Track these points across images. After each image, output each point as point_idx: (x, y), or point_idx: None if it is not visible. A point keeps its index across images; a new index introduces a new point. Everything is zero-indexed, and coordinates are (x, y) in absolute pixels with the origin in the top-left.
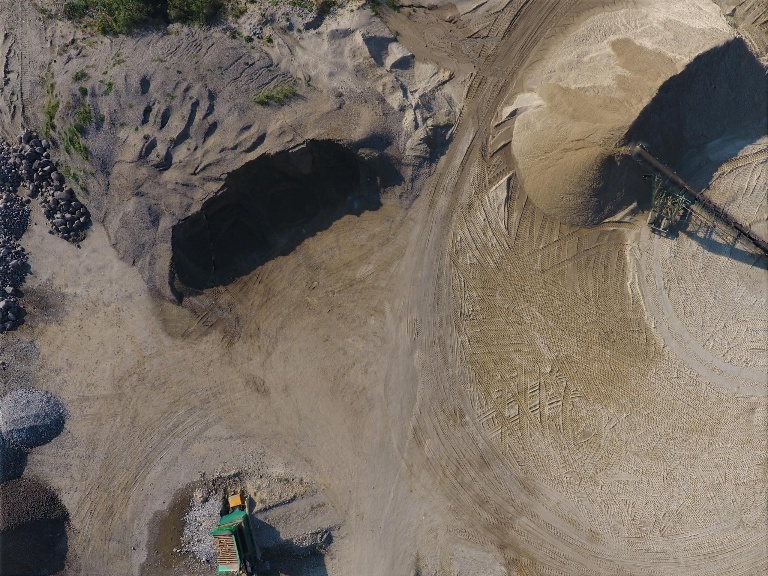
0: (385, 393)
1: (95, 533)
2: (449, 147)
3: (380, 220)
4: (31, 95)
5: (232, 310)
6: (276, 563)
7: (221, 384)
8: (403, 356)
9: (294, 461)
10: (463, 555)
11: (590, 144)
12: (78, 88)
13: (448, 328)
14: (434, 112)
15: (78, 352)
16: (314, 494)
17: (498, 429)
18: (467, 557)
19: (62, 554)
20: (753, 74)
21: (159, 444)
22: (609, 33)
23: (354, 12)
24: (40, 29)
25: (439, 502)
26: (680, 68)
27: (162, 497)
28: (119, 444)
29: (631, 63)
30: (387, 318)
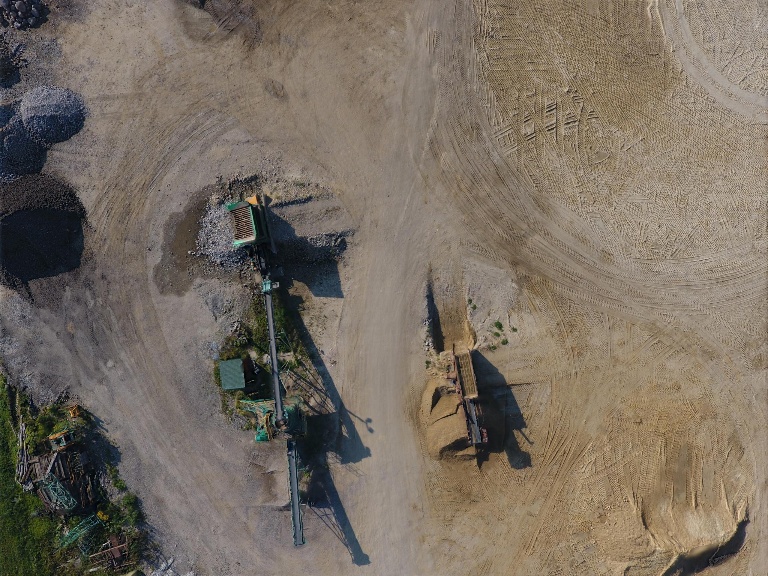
0: (403, 102)
1: (111, 232)
2: None
3: None
4: None
5: (253, 15)
6: (289, 270)
7: (240, 88)
8: (422, 67)
9: (311, 167)
10: (475, 269)
11: None
12: None
13: (467, 44)
14: None
15: (100, 51)
16: (330, 197)
17: (514, 146)
18: (479, 271)
19: (78, 251)
20: None
21: (177, 145)
22: None
23: None
24: None
25: (453, 215)
26: None
27: (179, 199)
28: (138, 144)
29: None
30: (407, 29)
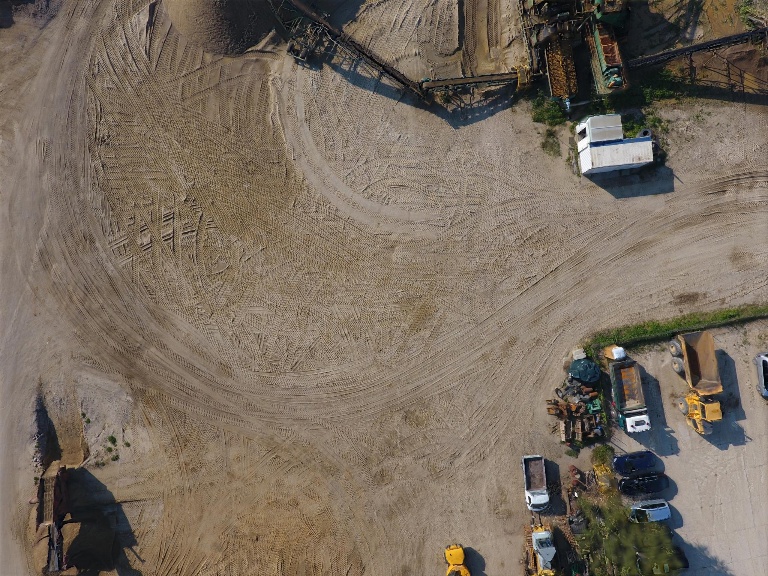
0: (10, 213)
1: None
2: None
3: (12, 38)
4: None
5: None
6: None
7: None
8: (31, 177)
9: None
10: (88, 382)
11: None
12: None
13: (81, 152)
14: None
15: None
16: None
17: (129, 257)
18: (92, 385)
19: None
20: None
21: None
22: None
23: None
24: None
25: (64, 327)
26: None
27: None
28: None
29: None
30: (15, 138)
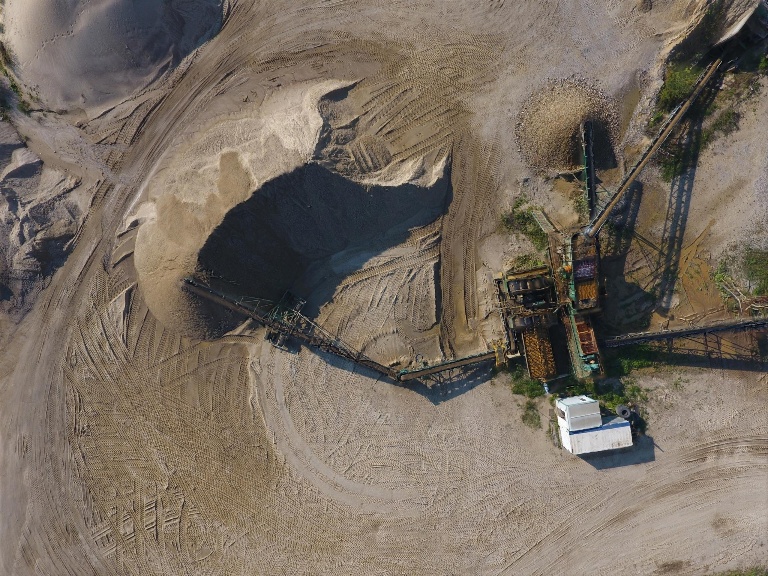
0: None
1: None
2: (68, 258)
3: None
4: None
5: None
6: None
7: None
8: (11, 474)
9: None
10: None
11: (178, 266)
12: None
13: (61, 444)
14: (50, 223)
15: None
16: None
17: (113, 547)
18: None
19: None
20: (352, 193)
21: None
22: (225, 144)
23: None
24: None
25: None
26: (249, 194)
27: None
28: None
29: (223, 182)
30: None
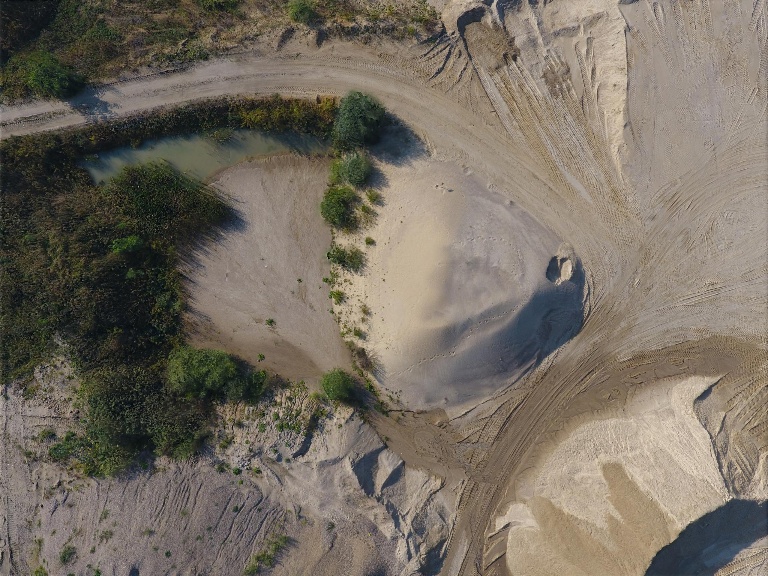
0: None
1: None
2: (443, 564)
3: None
4: (19, 539)
5: None
6: None
7: None
8: None
9: None
10: None
11: None
12: (66, 575)
13: None
14: (427, 532)
15: None
16: None
17: None
18: None
19: None
20: (746, 507)
21: None
22: (600, 450)
23: (342, 427)
24: (25, 472)
25: None
26: (673, 535)
27: None
28: None
29: (623, 505)
30: None
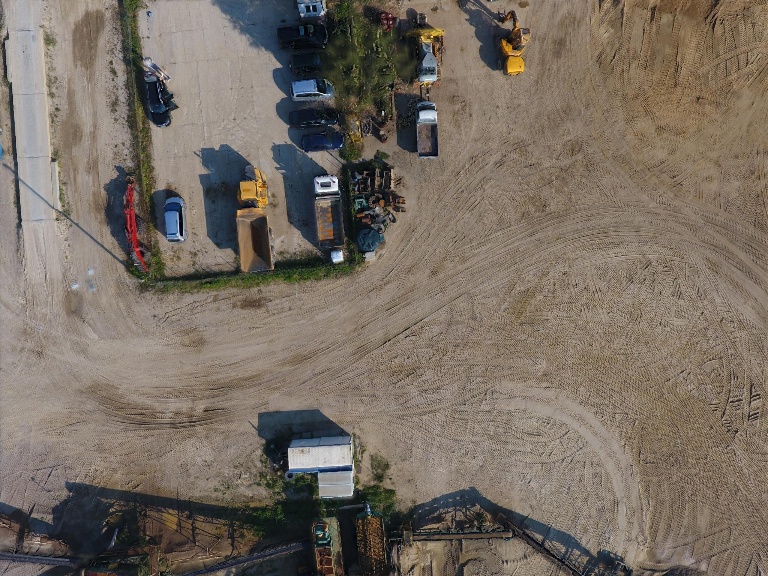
0: None
1: None
2: None
3: None
4: None
5: None
6: None
7: None
8: None
9: None
10: None
11: None
12: None
13: None
14: None
15: None
16: None
17: None
18: None
19: None
20: None
21: None
22: None
23: None
24: None
25: None
26: None
27: None
28: None
29: None
30: None
